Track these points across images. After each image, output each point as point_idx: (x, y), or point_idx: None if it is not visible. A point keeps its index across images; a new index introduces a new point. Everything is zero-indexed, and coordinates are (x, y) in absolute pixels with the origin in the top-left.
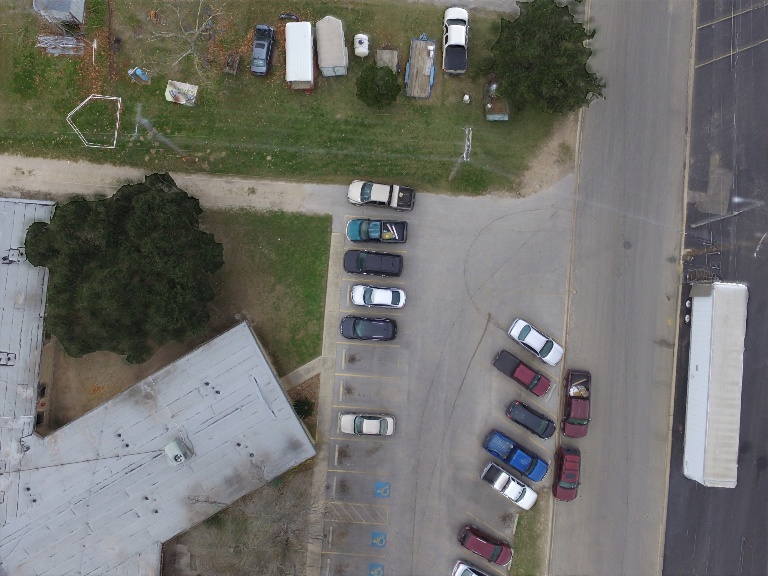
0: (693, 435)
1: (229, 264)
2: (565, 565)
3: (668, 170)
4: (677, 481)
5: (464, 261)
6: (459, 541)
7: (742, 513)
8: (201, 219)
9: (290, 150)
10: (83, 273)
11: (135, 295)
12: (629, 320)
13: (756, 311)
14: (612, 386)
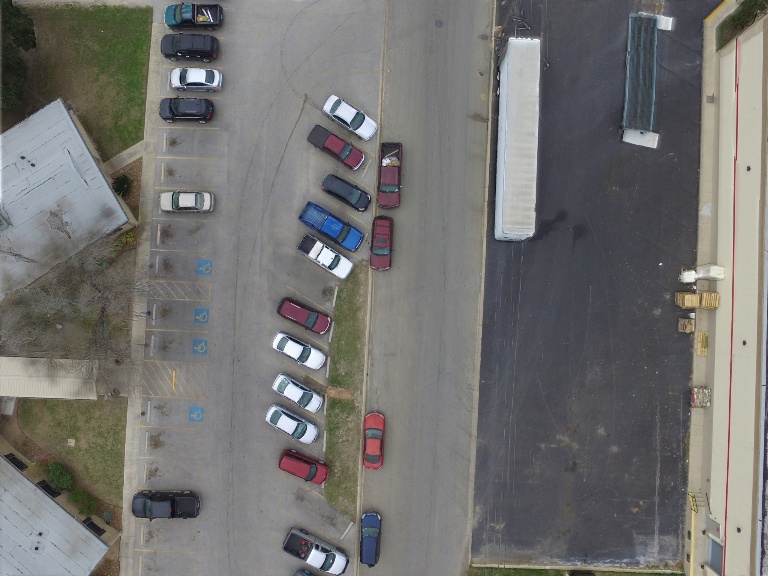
0: (499, 194)
1: (55, 58)
2: (385, 336)
3: None
4: (493, 250)
5: (280, 45)
6: None
7: (559, 280)
8: None
9: None
10: None
11: None
12: (441, 94)
13: (568, 83)
14: (427, 159)
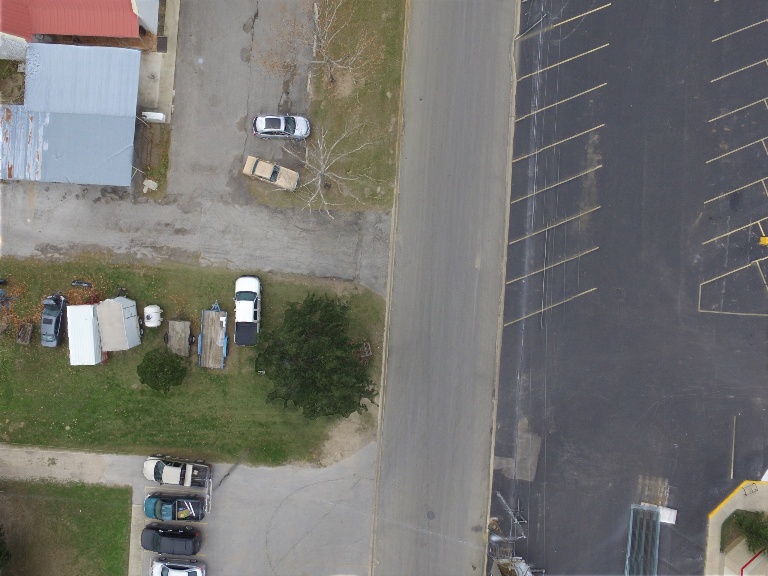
0: None
1: (32, 535)
2: None
3: (474, 436)
4: None
5: (266, 532)
6: None
7: None
8: (3, 490)
9: (88, 420)
10: None
11: None
12: None
13: None
14: None
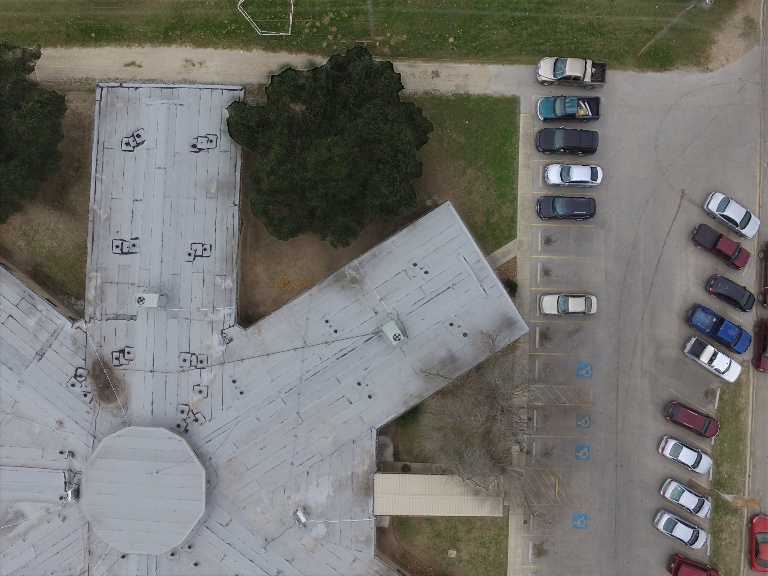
0: None
1: None
2: (767, 437)
3: None
4: None
5: (655, 138)
6: (664, 417)
7: None
8: None
9: (473, 31)
10: (298, 146)
11: (356, 165)
12: None
13: None
14: None
